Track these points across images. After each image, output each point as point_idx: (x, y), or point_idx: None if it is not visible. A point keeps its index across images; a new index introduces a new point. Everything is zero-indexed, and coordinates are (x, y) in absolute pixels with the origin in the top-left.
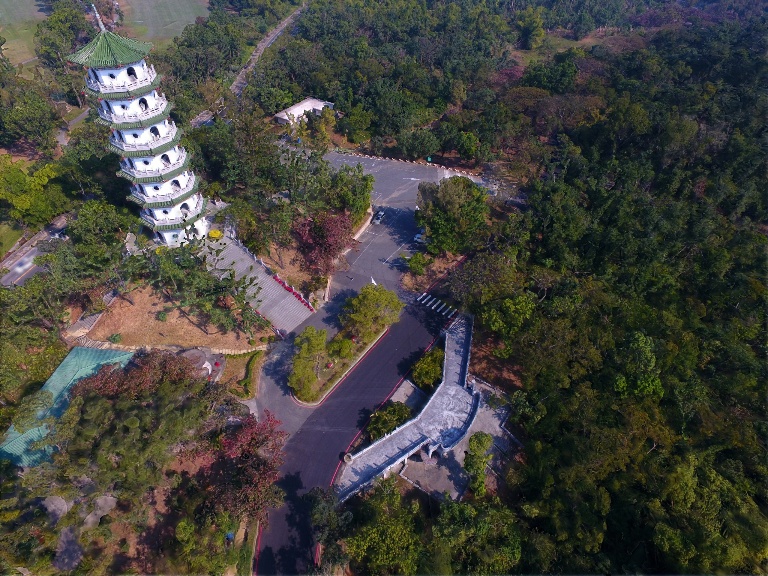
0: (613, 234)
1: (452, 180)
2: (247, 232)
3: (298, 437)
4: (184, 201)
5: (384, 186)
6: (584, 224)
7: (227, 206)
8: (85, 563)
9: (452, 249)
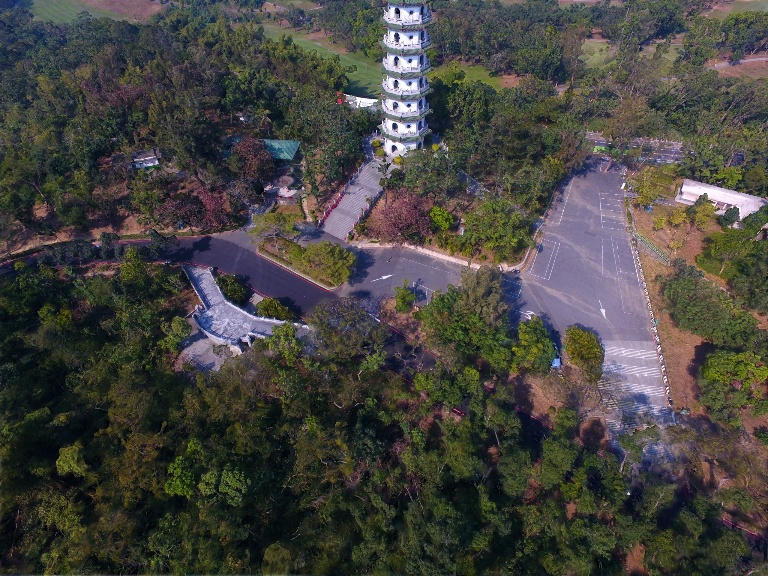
0: (439, 505)
1: (576, 330)
2: (395, 170)
3: (235, 246)
4: (396, 122)
5: (568, 281)
6: (465, 467)
7: (416, 149)
8: (178, 179)
9: (425, 326)
